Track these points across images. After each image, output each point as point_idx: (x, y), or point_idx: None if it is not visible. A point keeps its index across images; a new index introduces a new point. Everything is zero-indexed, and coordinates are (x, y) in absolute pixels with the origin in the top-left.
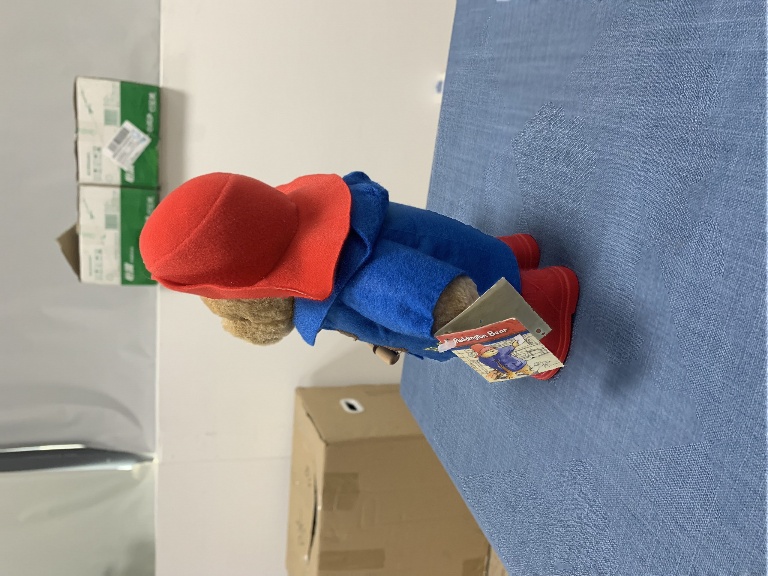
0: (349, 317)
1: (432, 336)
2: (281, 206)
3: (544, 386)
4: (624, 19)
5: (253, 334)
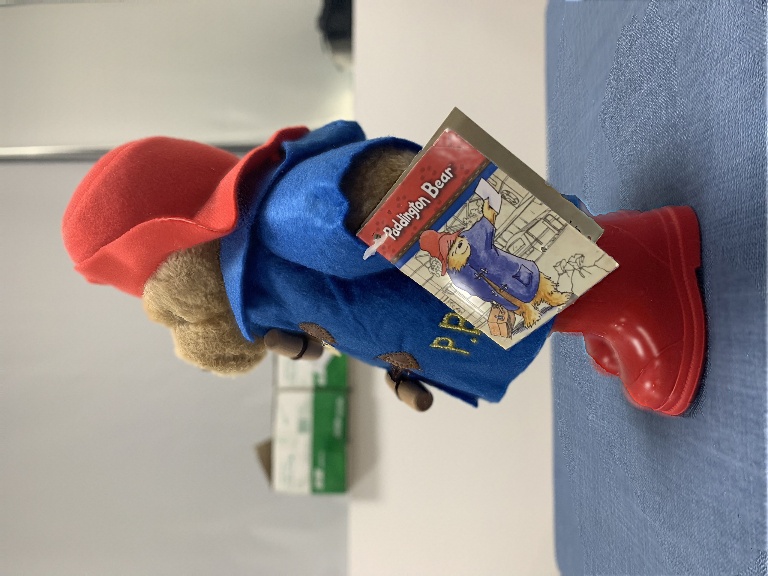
0: (285, 278)
1: (352, 235)
2: (214, 155)
3: (689, 428)
4: None
5: (197, 345)
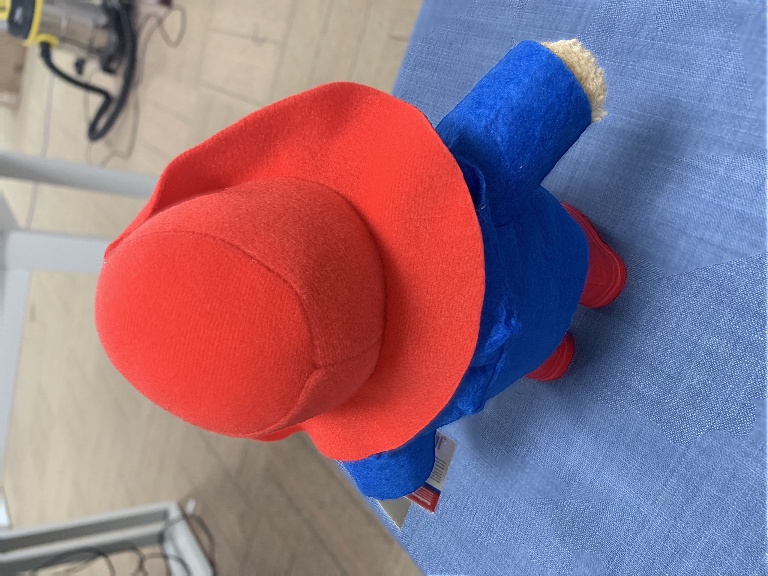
0: None
1: None
2: None
3: None
4: None
5: None
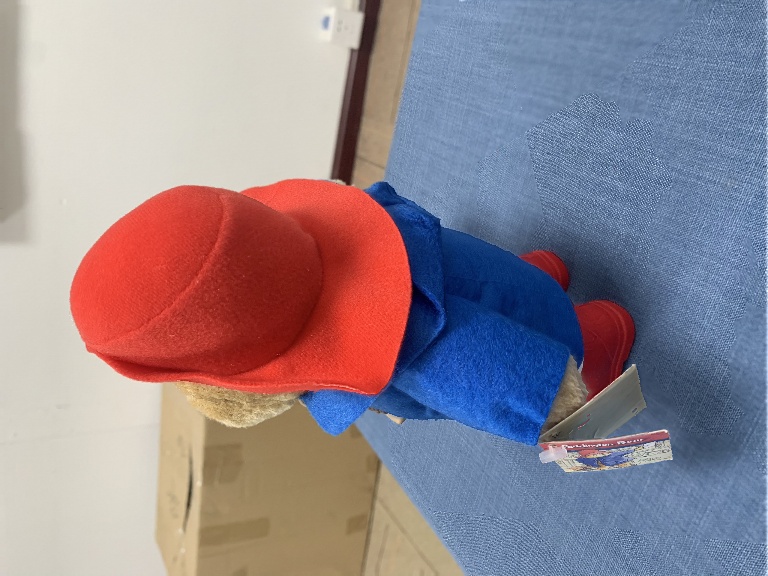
0: (394, 400)
1: None
2: (301, 246)
3: None
4: (735, 6)
5: (241, 416)
